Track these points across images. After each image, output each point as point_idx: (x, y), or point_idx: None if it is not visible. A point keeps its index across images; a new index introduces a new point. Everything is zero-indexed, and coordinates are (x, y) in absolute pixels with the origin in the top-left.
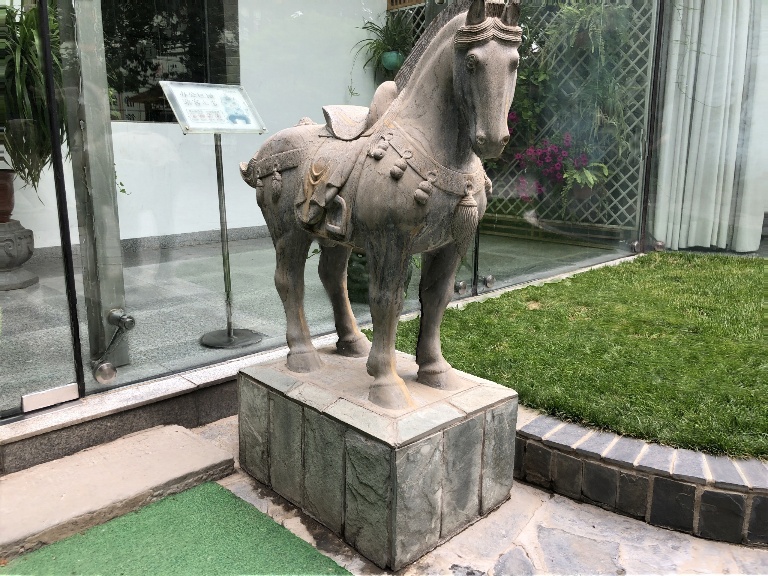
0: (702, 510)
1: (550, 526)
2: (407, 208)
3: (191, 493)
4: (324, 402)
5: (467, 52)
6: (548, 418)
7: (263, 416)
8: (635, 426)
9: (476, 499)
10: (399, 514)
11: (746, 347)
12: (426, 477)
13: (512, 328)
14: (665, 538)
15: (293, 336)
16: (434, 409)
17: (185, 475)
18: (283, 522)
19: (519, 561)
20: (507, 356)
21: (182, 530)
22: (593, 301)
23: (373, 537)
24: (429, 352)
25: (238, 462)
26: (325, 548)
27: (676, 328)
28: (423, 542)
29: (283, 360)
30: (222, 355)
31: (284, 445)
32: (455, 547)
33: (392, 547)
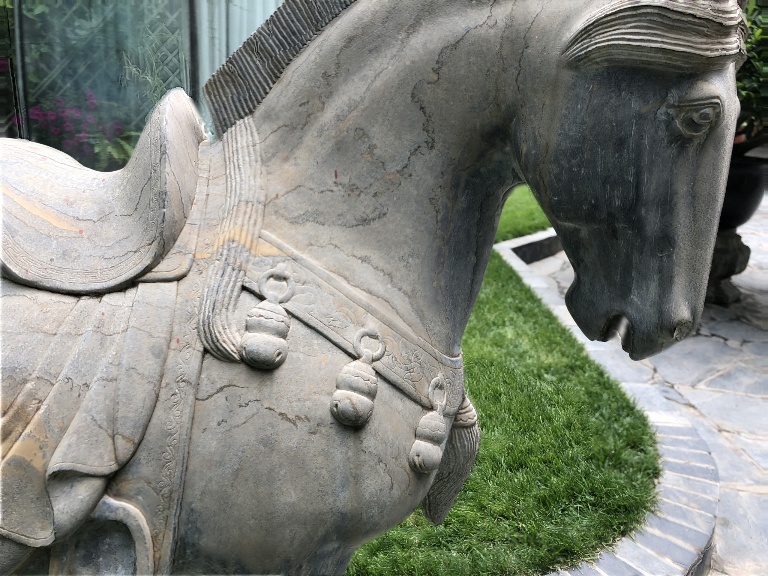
0: None
1: None
2: (393, 501)
3: None
4: None
5: (690, 85)
6: None
7: None
8: (488, 569)
9: None
10: None
11: None
12: None
13: None
14: None
15: None
16: None
17: None
18: None
19: None
20: None
21: None
22: None
23: None
24: None
25: None
26: None
27: None
28: None
29: None
30: None
31: None
32: None
33: None
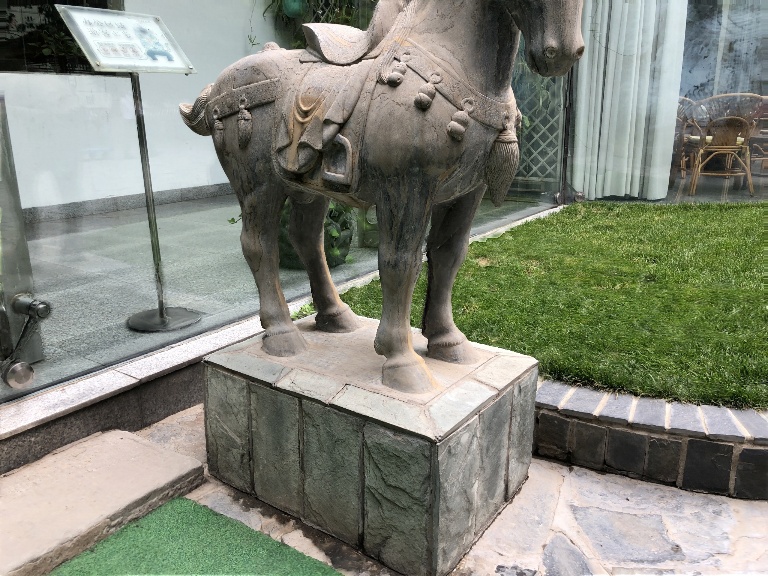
0: (739, 469)
1: (583, 504)
2: (438, 146)
3: (158, 515)
4: (328, 391)
5: None
6: (555, 384)
7: (241, 413)
8: (652, 385)
9: (503, 484)
10: (441, 518)
11: (711, 292)
12: (465, 470)
13: (475, 287)
14: (704, 503)
15: (270, 313)
16: (462, 388)
17: (148, 494)
18: (282, 538)
19: (566, 551)
20: (484, 318)
21: (159, 566)
22: (543, 254)
23: (406, 547)
24: (441, 321)
25: (205, 468)
26: (343, 565)
27: (634, 277)
28: (461, 544)
29: (256, 343)
30: (159, 340)
31: (273, 446)
32: (491, 543)
33: (433, 557)
